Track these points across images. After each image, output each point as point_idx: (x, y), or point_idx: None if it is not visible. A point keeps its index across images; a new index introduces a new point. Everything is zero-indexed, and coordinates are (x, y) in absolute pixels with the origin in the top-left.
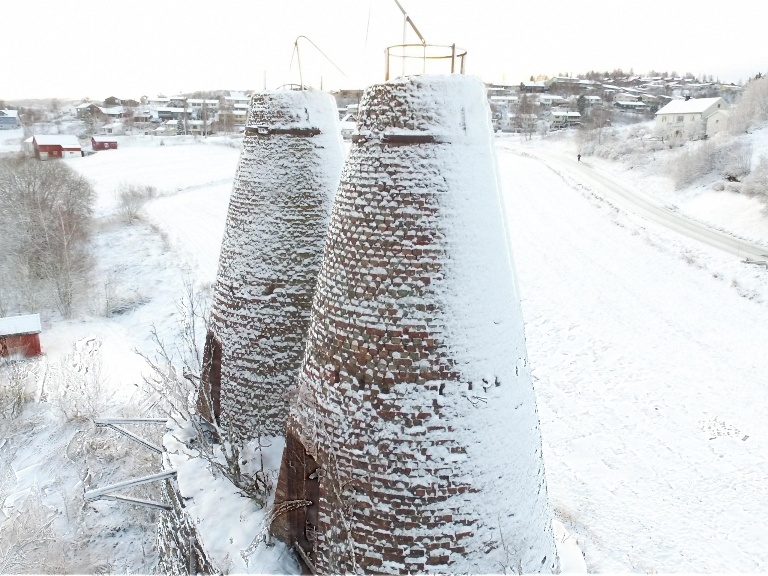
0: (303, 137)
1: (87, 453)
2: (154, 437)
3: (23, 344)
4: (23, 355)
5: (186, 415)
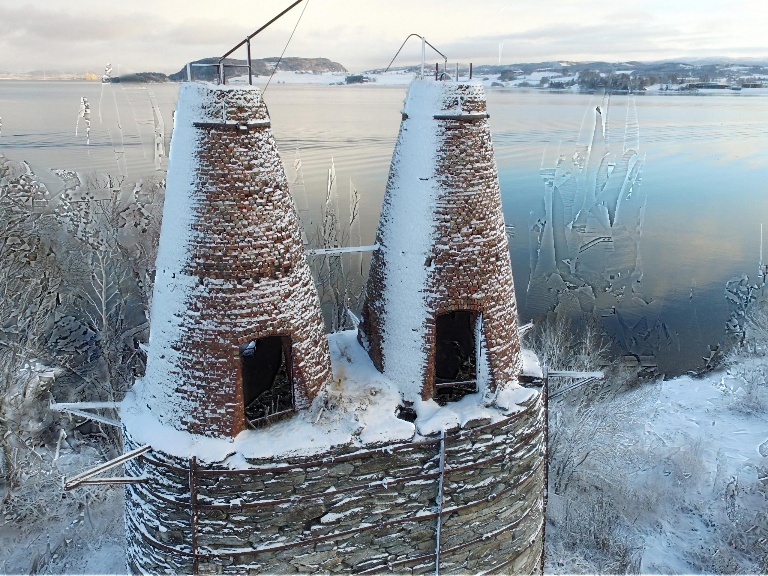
0: None
1: None
2: None
3: None
4: None
5: None
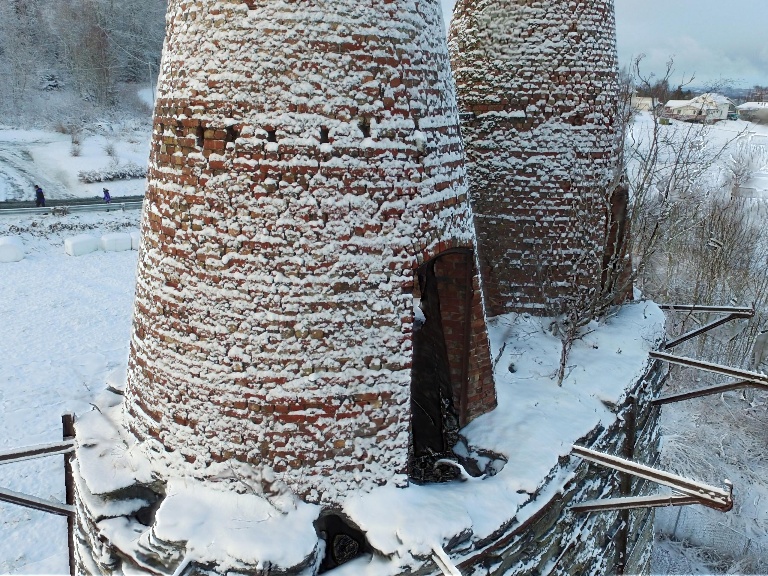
0: None
1: None
2: None
3: None
4: None
5: (417, 506)
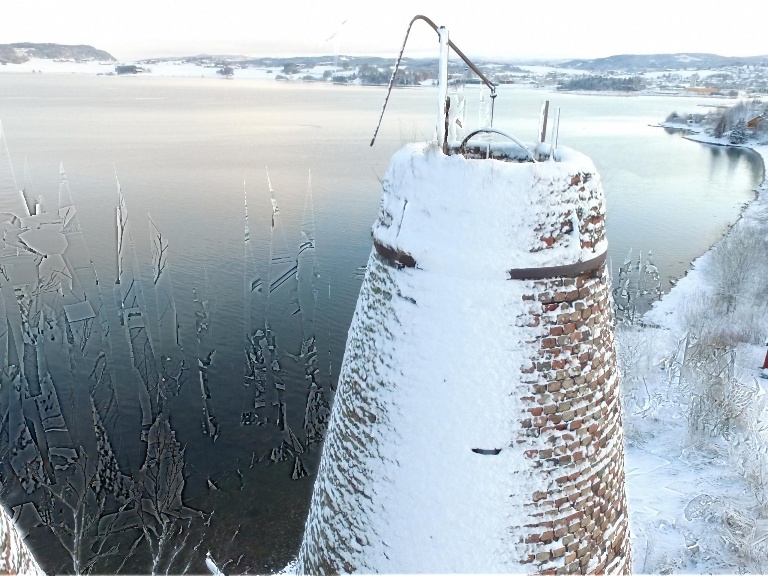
0: (387, 264)
1: (722, 522)
2: (764, 569)
3: (751, 367)
4: (746, 379)
5: None
